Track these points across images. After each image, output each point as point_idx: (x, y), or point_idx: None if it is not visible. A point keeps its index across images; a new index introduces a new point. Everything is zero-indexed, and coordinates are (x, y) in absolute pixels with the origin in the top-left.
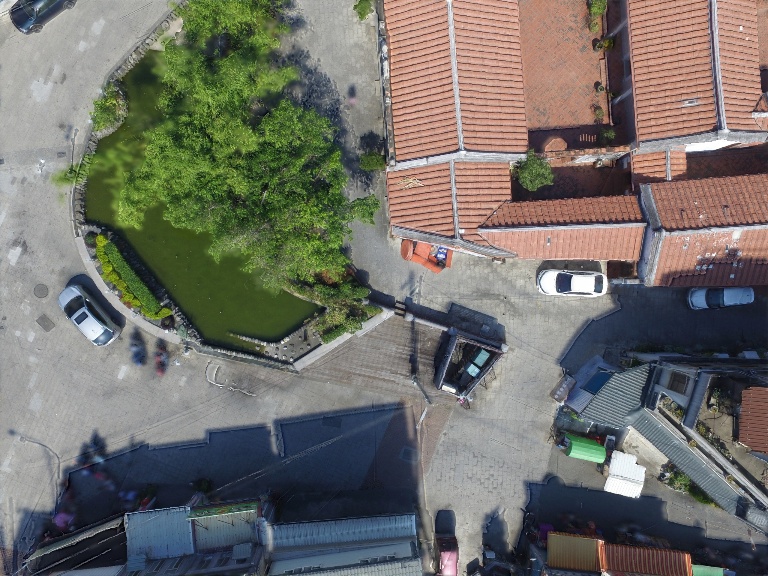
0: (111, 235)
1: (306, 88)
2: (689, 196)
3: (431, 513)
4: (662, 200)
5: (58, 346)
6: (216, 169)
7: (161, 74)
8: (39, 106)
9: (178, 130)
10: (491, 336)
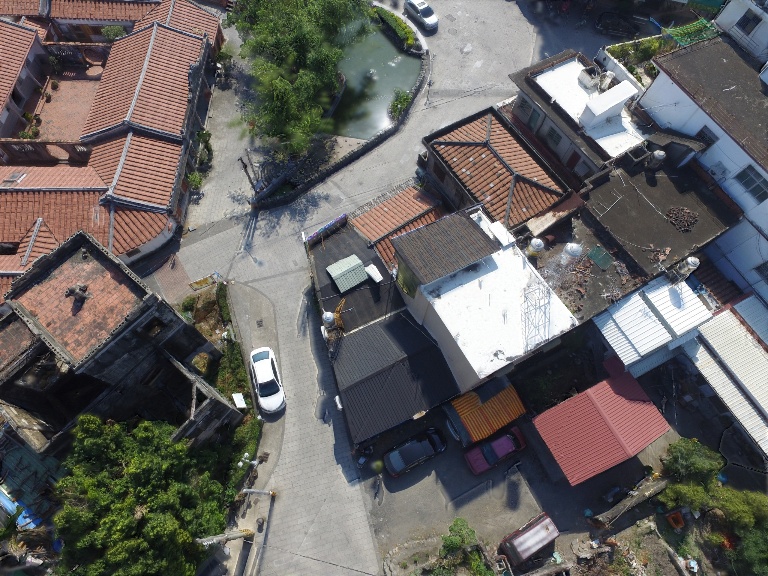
0: (405, 47)
1: (263, 118)
2: (15, 3)
3: None
4: (34, 3)
5: (444, 8)
6: (308, 6)
7: (364, 129)
8: (449, 119)
9: (324, 13)
10: None
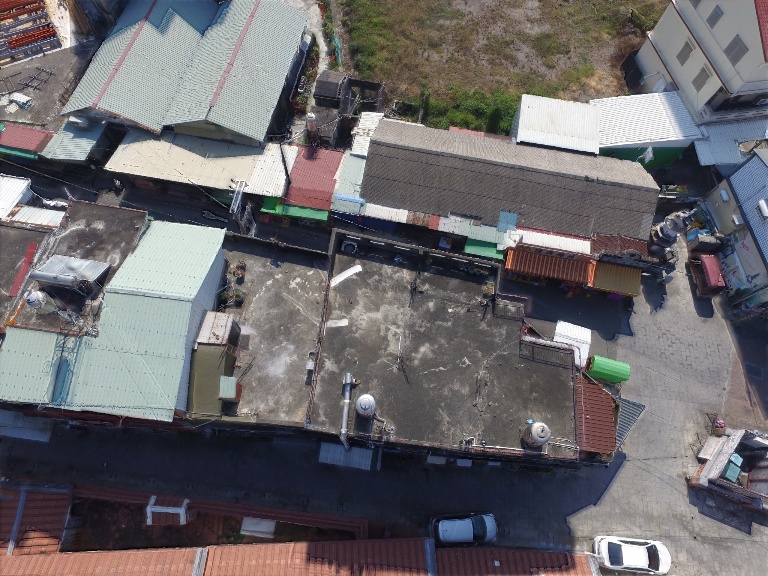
0: None
1: None
2: None
3: (719, 316)
4: None
5: None
6: None
7: None
8: None
9: None
10: (704, 493)
